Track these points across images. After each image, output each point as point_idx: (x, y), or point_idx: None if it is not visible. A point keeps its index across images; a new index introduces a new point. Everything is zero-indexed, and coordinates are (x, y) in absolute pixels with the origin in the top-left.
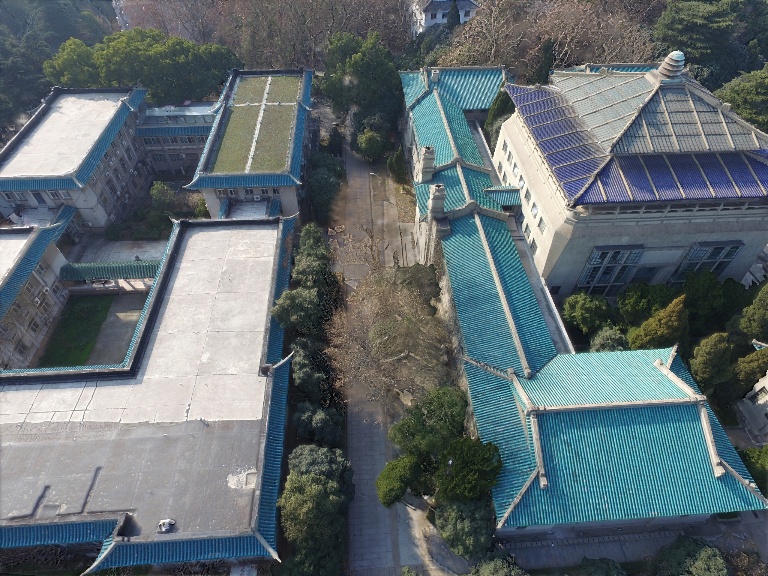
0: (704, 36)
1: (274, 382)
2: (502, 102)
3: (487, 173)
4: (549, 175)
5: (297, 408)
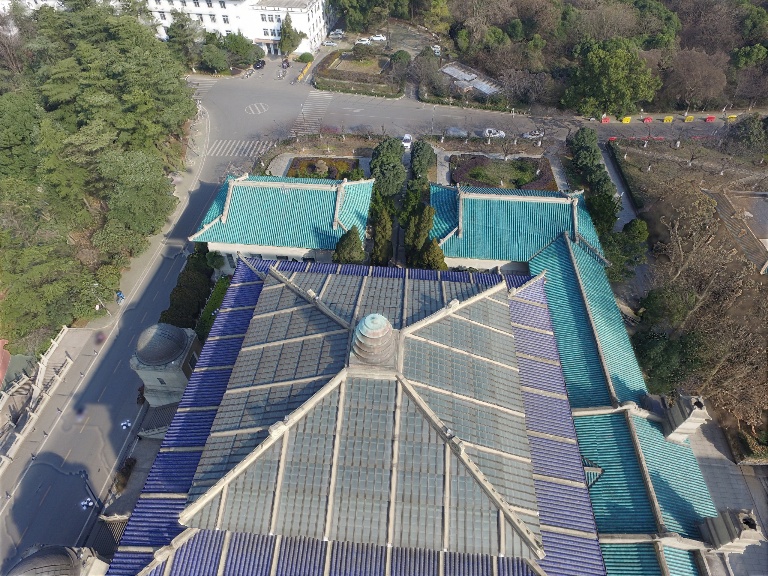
0: None
1: (761, 253)
2: None
3: None
4: None
5: None
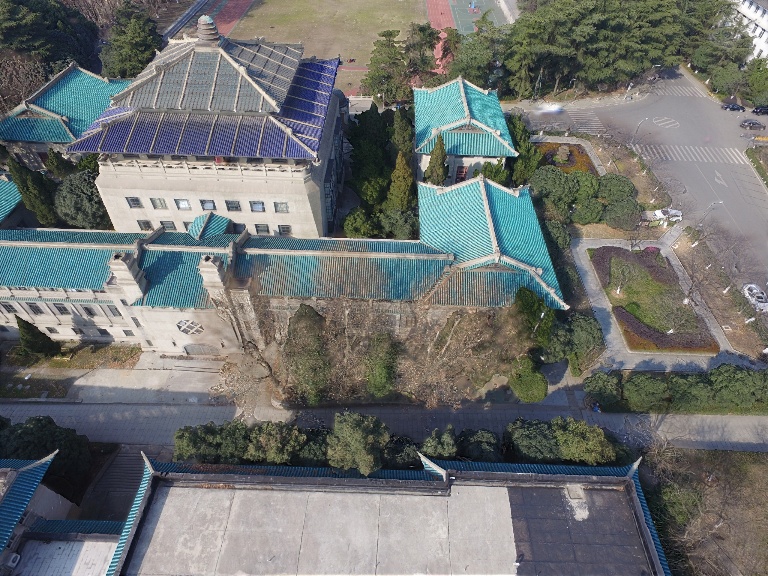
0: (30, 35)
1: None
2: (35, 183)
3: (162, 232)
4: (241, 171)
5: (478, 458)
